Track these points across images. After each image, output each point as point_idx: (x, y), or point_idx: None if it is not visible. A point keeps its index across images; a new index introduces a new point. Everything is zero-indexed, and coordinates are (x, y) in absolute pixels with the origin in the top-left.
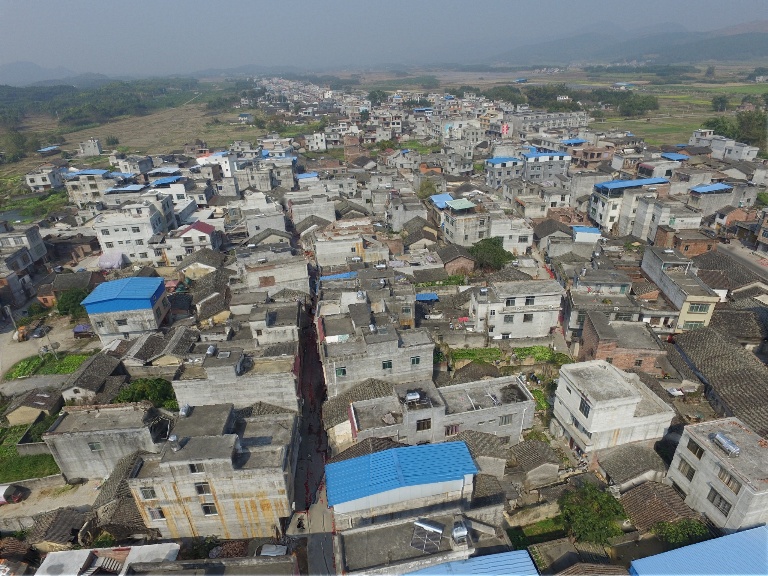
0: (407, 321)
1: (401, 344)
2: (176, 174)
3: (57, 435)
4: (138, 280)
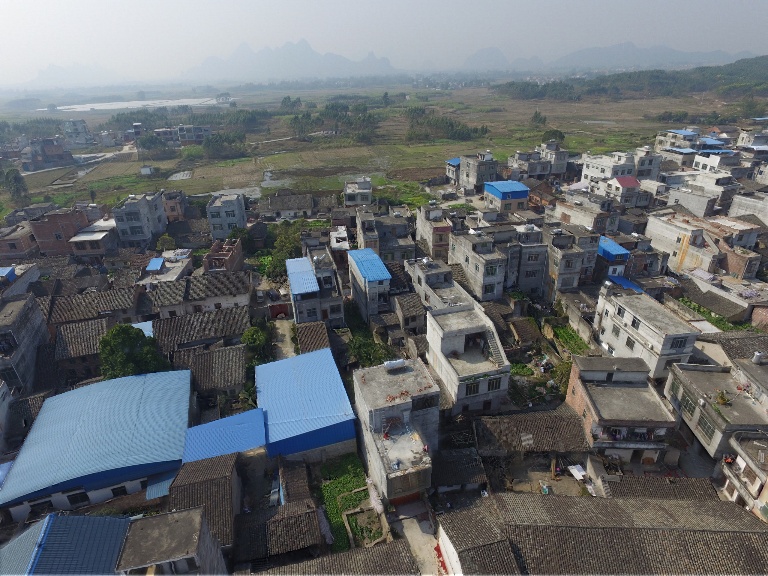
0: (554, 274)
1: (482, 253)
2: (763, 153)
3: (390, 208)
4: (518, 184)
